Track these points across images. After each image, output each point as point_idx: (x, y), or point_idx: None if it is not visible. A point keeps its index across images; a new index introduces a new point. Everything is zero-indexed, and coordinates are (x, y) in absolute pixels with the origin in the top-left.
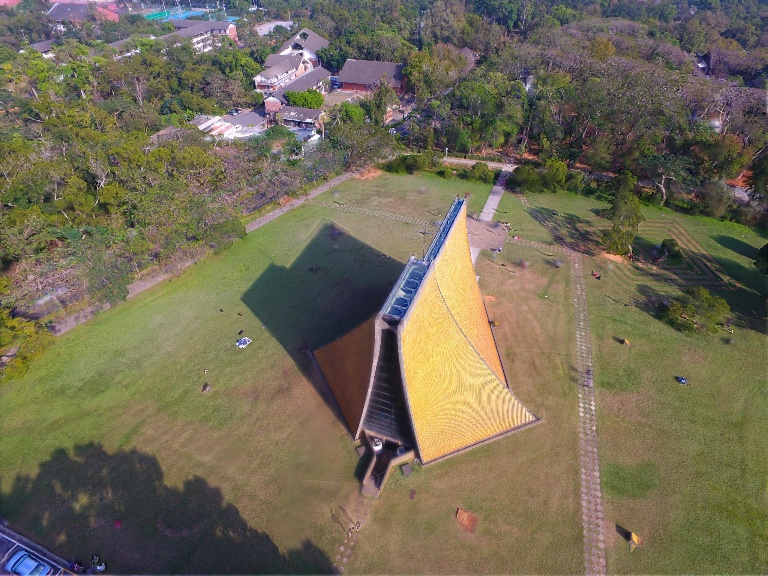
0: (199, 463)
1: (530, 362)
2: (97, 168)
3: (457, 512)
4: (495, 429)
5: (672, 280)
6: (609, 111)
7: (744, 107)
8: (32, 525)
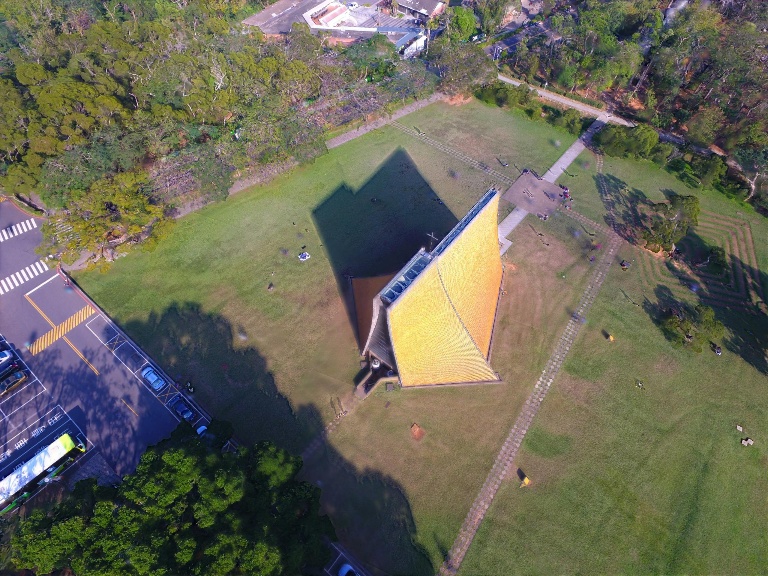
0: (256, 341)
1: (517, 333)
2: (216, 73)
3: (413, 425)
4: (463, 378)
5: (697, 289)
6: (738, 78)
7: None
8: (156, 353)
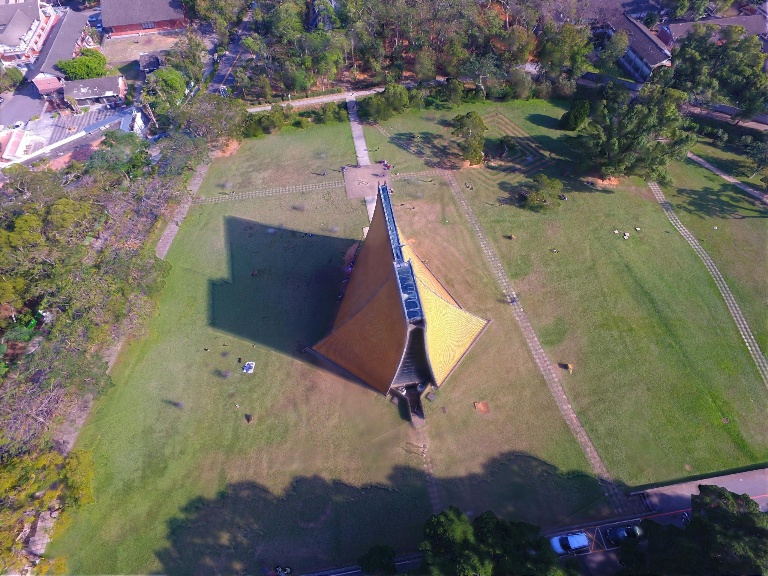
0: (292, 472)
1: (464, 281)
2: None
3: (475, 405)
4: (469, 341)
5: (518, 170)
6: (419, 21)
7: None
8: None
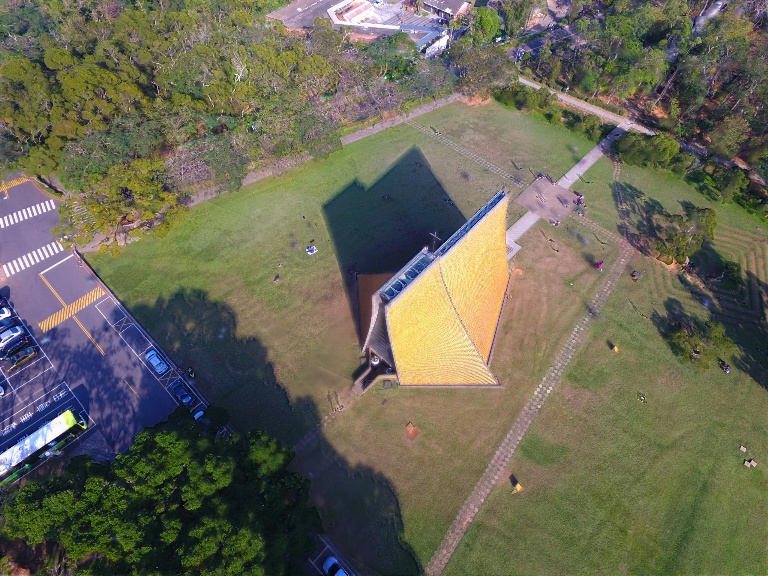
0: (259, 332)
1: (520, 338)
2: (236, 65)
3: (408, 424)
4: (462, 380)
5: (709, 304)
6: (766, 90)
7: None
8: (161, 337)
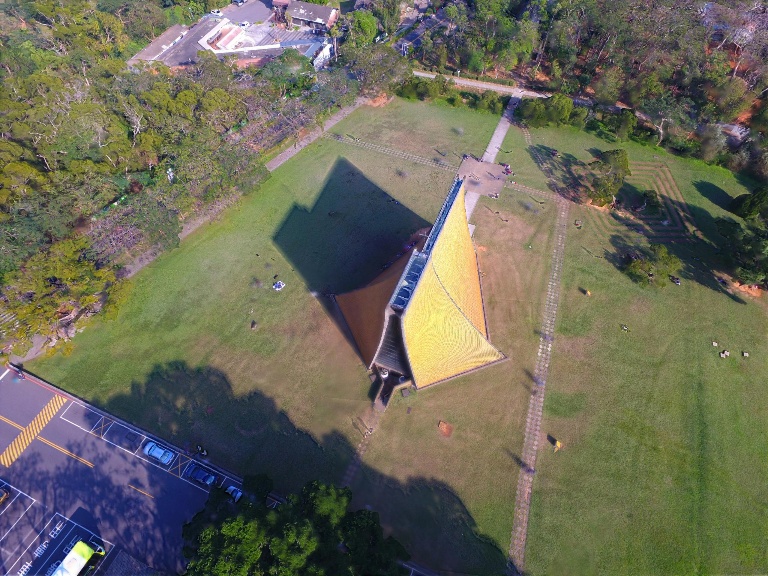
0: (257, 384)
1: (507, 309)
2: (132, 116)
3: (439, 423)
4: (472, 365)
5: (644, 231)
6: (625, 39)
7: (759, 45)
8: (152, 425)
